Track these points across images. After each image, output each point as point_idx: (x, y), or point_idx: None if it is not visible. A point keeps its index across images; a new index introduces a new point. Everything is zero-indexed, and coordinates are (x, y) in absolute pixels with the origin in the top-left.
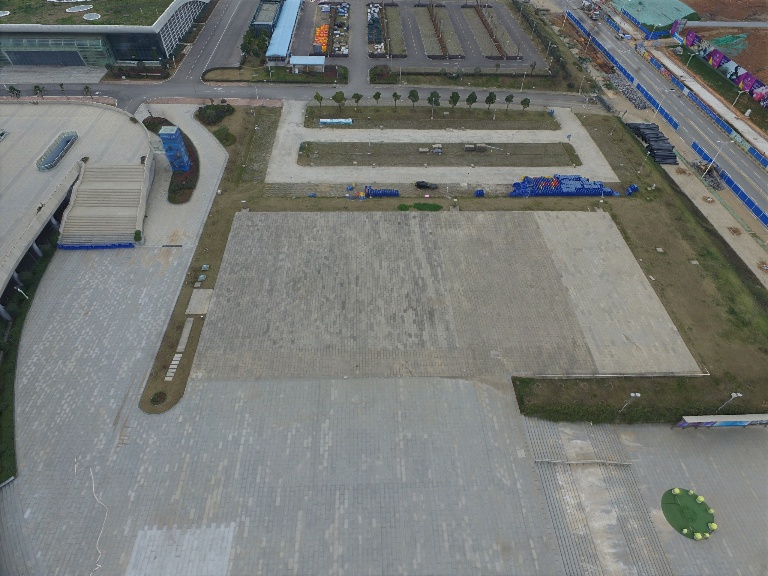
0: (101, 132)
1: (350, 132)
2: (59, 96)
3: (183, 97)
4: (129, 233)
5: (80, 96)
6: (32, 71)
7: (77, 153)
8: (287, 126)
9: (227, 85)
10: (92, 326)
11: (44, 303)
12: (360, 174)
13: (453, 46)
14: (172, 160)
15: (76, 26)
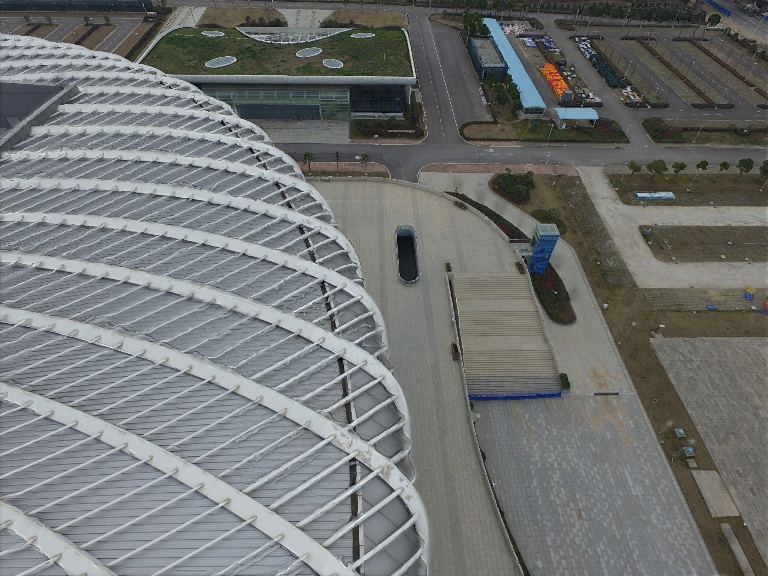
0: (434, 223)
1: (682, 211)
2: (316, 162)
3: (459, 163)
4: (547, 375)
5: (340, 162)
6: (264, 127)
7: (429, 257)
8: (603, 203)
9: (496, 145)
10: (603, 539)
11: (512, 496)
12: (743, 274)
13: (707, 91)
14: (534, 262)
15: (328, 77)
